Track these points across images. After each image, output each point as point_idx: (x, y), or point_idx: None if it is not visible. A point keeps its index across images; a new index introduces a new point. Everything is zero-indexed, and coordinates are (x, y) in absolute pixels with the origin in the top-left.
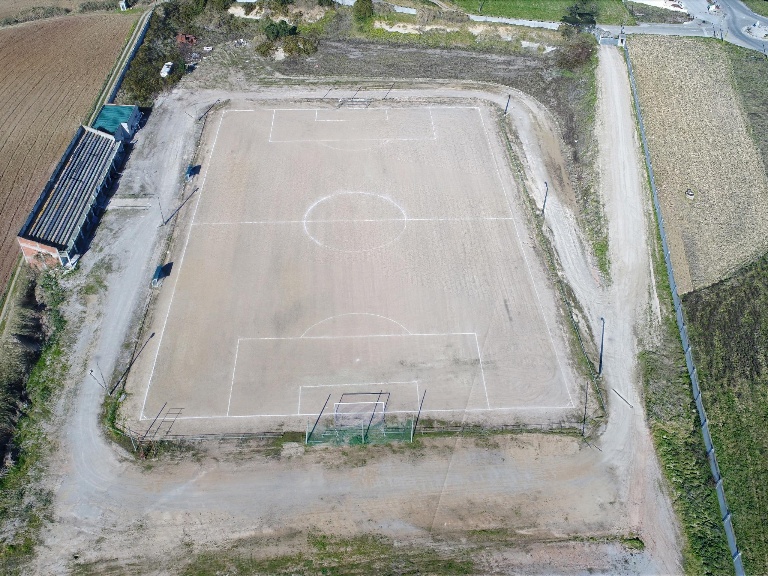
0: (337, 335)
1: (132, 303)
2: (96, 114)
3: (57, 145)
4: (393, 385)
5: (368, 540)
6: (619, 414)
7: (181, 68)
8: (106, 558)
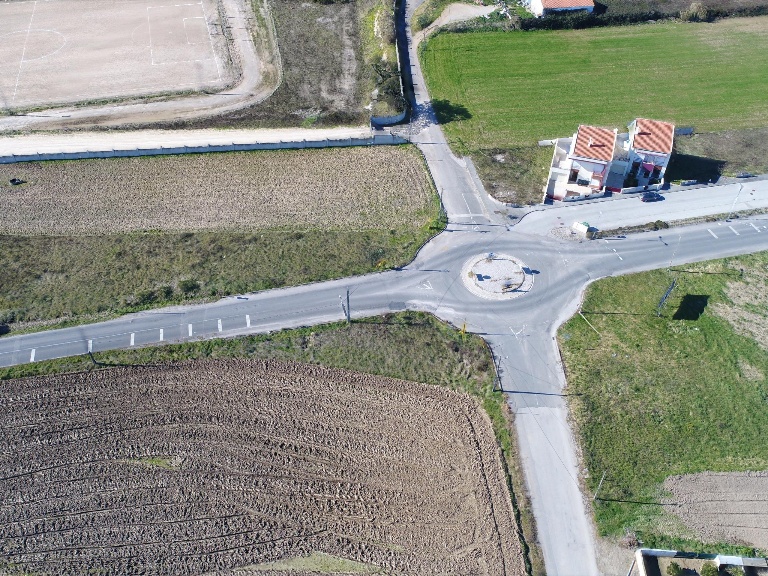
0: None
1: None
2: None
3: None
4: None
5: None
6: None
7: None
8: None
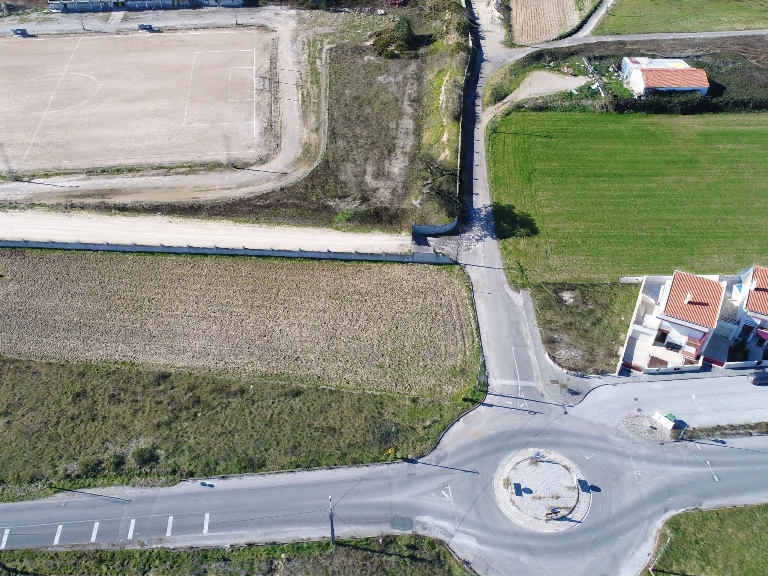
0: None
1: (2, 31)
2: None
3: None
4: None
5: None
6: None
7: None
8: None
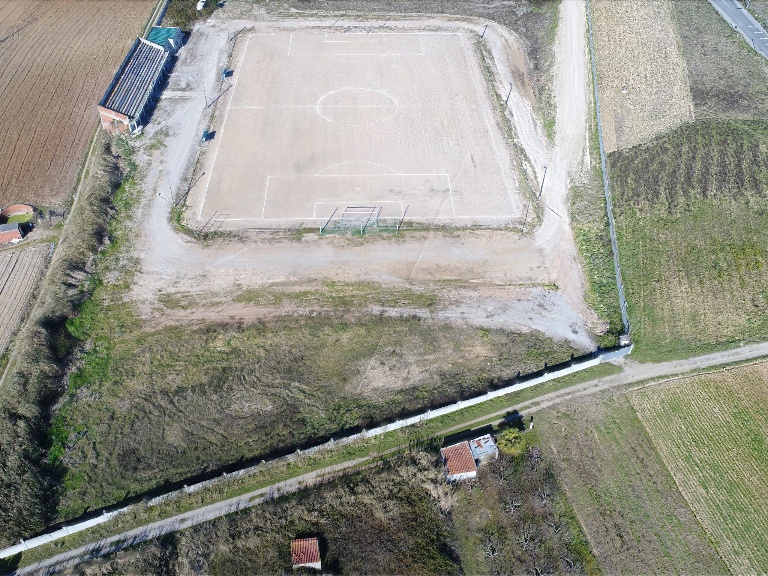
0: (343, 174)
1: (186, 155)
2: (146, 34)
3: (116, 56)
4: (384, 203)
5: (364, 284)
6: (550, 220)
7: (213, 3)
8: (181, 291)
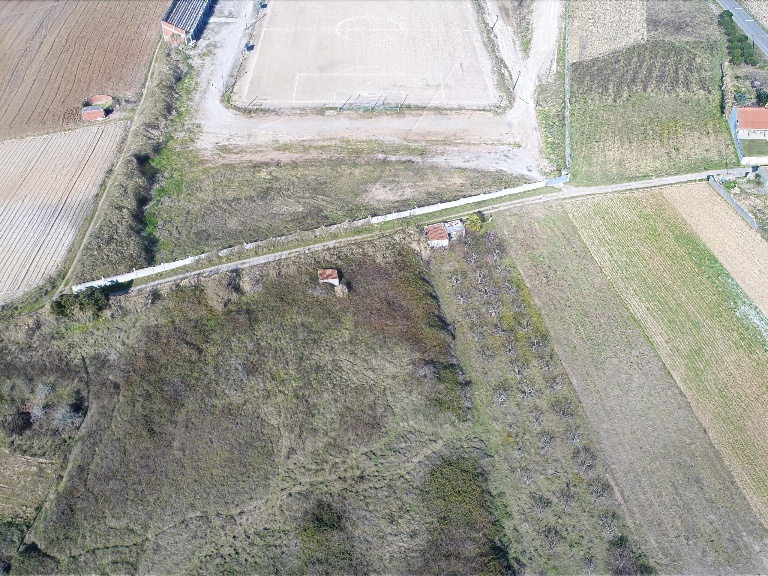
0: (357, 74)
1: (232, 60)
2: None
3: None
4: (389, 92)
5: (372, 141)
6: (520, 105)
7: None
8: (233, 144)
